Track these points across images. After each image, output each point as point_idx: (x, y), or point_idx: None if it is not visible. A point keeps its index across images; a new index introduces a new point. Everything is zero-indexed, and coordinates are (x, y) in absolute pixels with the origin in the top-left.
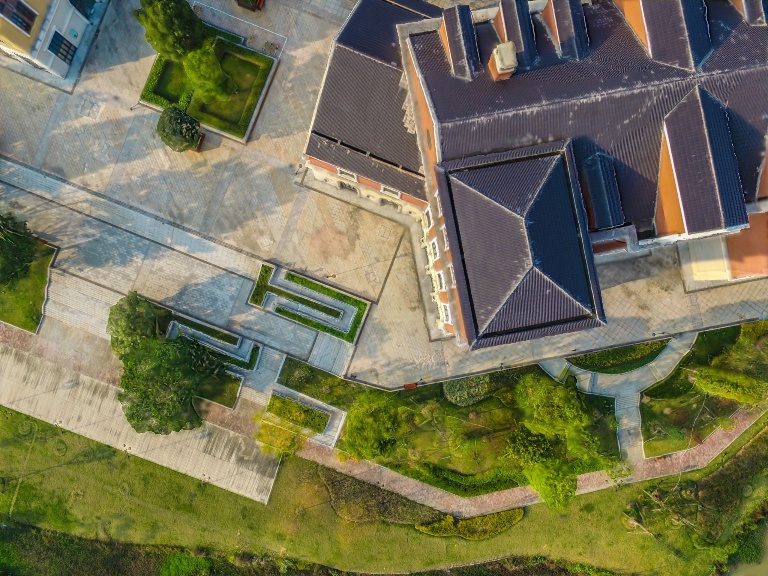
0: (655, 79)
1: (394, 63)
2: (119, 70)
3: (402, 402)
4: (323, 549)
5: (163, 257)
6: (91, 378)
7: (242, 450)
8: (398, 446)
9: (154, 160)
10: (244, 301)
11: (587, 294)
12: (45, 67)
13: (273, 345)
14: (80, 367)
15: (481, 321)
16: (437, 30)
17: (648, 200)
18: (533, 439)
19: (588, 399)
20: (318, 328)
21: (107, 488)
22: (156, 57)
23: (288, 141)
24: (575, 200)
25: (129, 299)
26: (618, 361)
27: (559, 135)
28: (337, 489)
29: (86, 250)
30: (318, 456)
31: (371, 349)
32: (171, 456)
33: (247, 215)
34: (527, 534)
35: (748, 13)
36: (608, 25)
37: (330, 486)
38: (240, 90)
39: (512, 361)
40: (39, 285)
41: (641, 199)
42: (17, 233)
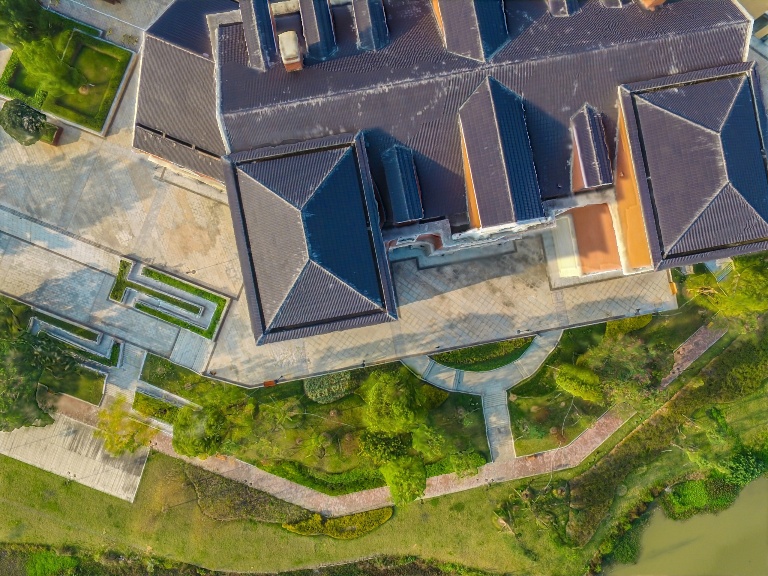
0: (444, 70)
1: (206, 54)
2: None
3: (262, 399)
4: (189, 548)
5: (23, 252)
6: None
7: (108, 448)
8: (252, 444)
9: (11, 154)
10: (105, 297)
11: (377, 288)
12: None
13: (135, 341)
14: None
15: (267, 315)
16: None
17: (458, 194)
18: (383, 437)
19: (453, 397)
20: (178, 324)
21: None
22: None
23: None
24: (365, 193)
25: None
26: (481, 358)
27: (351, 127)
28: (204, 487)
29: None
30: None
31: (231, 346)
32: (36, 454)
33: (106, 210)
34: (396, 533)
35: (551, 4)
36: (415, 16)
37: (196, 484)
38: (97, 83)
39: (374, 358)
40: None
41: (450, 193)
42: None
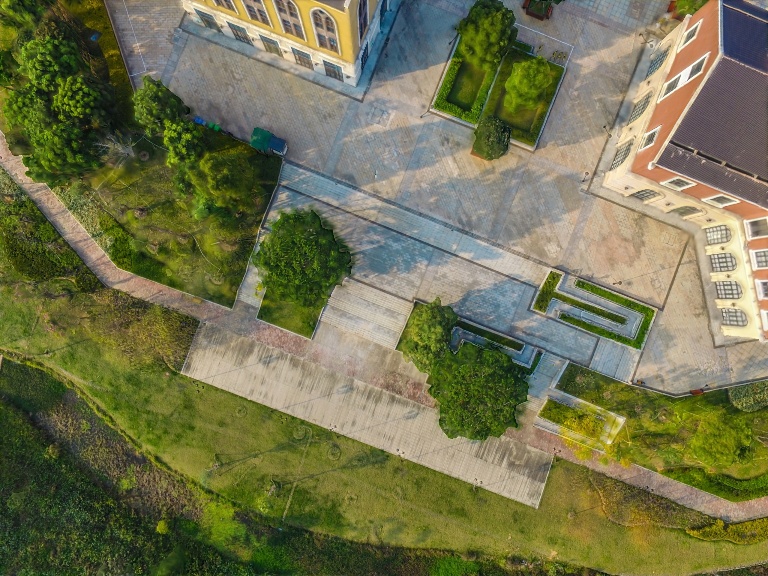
0: None
1: None
2: (409, 78)
3: (688, 408)
4: (594, 553)
5: (446, 263)
6: (365, 383)
7: (513, 455)
8: None
9: (443, 167)
10: (526, 307)
11: None
12: (352, 76)
13: (554, 351)
14: (354, 372)
15: None
16: None
17: None
18: None
19: None
20: (603, 334)
21: (380, 492)
22: (445, 65)
23: (574, 149)
24: None
25: (436, 306)
26: None
27: None
28: (608, 493)
29: (371, 256)
30: (588, 461)
31: (657, 355)
32: (444, 461)
33: (534, 222)
34: None
35: None
36: None
37: (601, 491)
38: None
39: None
40: None
41: None
42: None
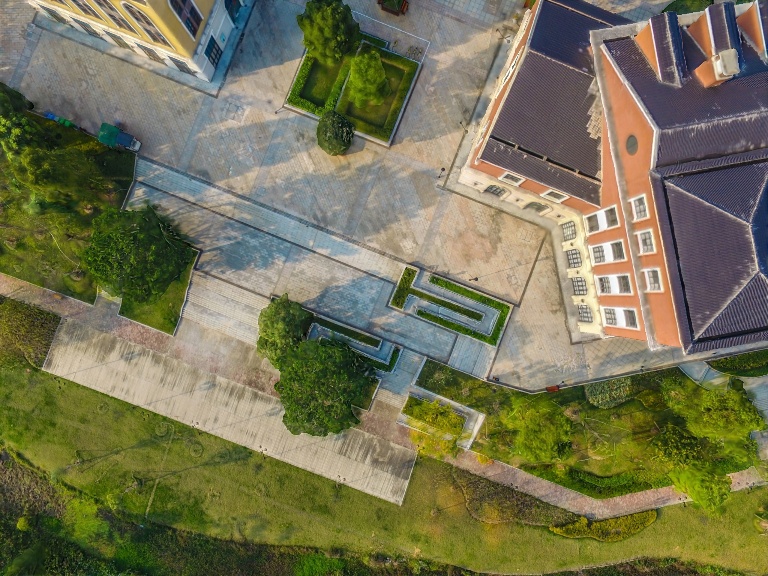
0: None
1: (585, 69)
2: (264, 74)
3: (544, 404)
4: (457, 550)
5: (304, 260)
6: (227, 380)
7: (377, 452)
8: None
9: (298, 163)
10: (384, 304)
11: None
12: (199, 71)
13: (413, 347)
14: (217, 369)
15: (697, 326)
16: (630, 36)
17: None
18: (686, 442)
19: None
20: (459, 331)
21: (243, 489)
22: (300, 61)
23: (431, 145)
24: None
25: (282, 302)
26: (758, 364)
27: None
28: (472, 491)
29: (228, 252)
30: (452, 458)
31: (513, 352)
32: (307, 457)
33: (390, 218)
34: (659, 536)
35: None
36: None
37: (465, 488)
38: None
39: (652, 364)
40: (180, 287)
41: None
42: None
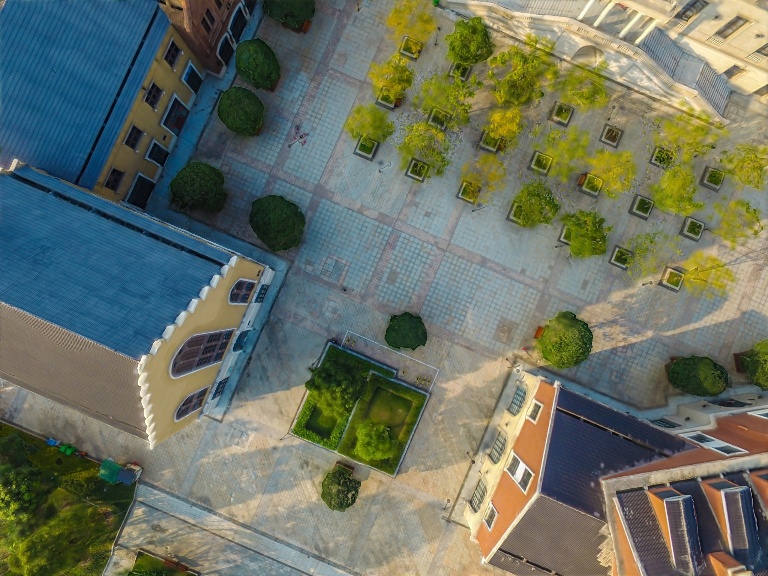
0: None
1: (597, 514)
2: (270, 399)
3: None
4: None
5: None
6: None
7: None
8: None
9: (301, 491)
10: None
11: None
12: None
13: None
14: None
15: None
16: (644, 487)
17: None
18: None
19: None
20: None
21: None
22: None
23: (437, 475)
24: None
25: None
26: None
27: None
28: None
29: None
30: None
31: None
32: None
33: (393, 550)
34: None
35: None
36: None
37: None
38: (392, 426)
39: None
40: None
41: None
42: (158, 557)
